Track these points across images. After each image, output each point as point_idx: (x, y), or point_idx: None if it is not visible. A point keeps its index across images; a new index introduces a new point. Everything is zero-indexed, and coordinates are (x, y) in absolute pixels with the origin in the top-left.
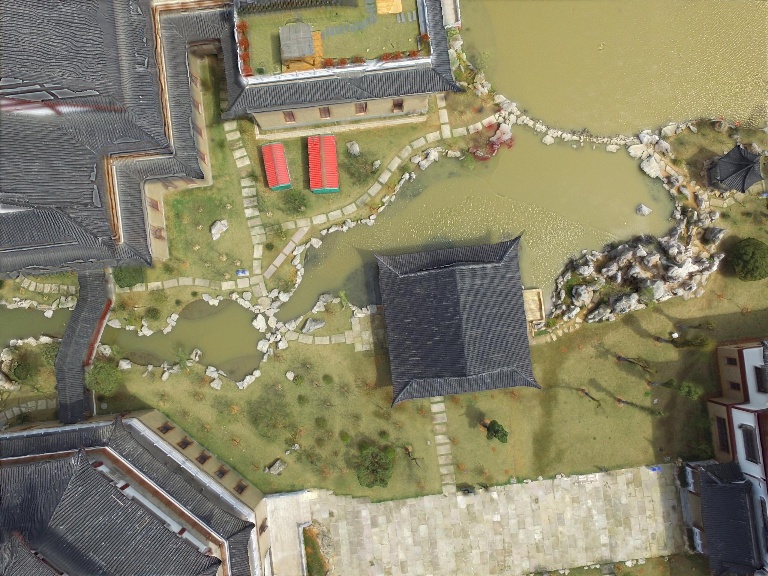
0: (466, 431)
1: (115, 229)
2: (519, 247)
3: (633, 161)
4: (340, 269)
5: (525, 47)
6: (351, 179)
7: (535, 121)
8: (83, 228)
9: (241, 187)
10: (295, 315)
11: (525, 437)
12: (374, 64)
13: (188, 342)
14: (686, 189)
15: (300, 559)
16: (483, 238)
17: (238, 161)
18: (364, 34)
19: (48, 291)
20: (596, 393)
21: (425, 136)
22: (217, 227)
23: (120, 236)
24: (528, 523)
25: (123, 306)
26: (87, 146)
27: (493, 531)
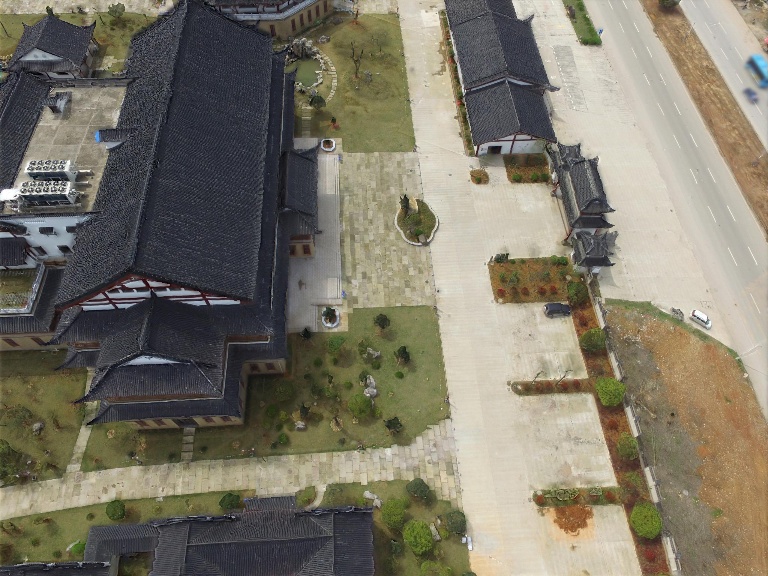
0: None
1: None
2: None
3: None
4: None
5: None
6: None
7: None
8: None
9: None
10: None
11: None
12: None
13: None
14: None
15: None
16: None
17: None
18: None
19: None
20: (2, 35)
21: None
22: None
23: None
24: (60, 2)
25: None
26: None
27: (77, 1)
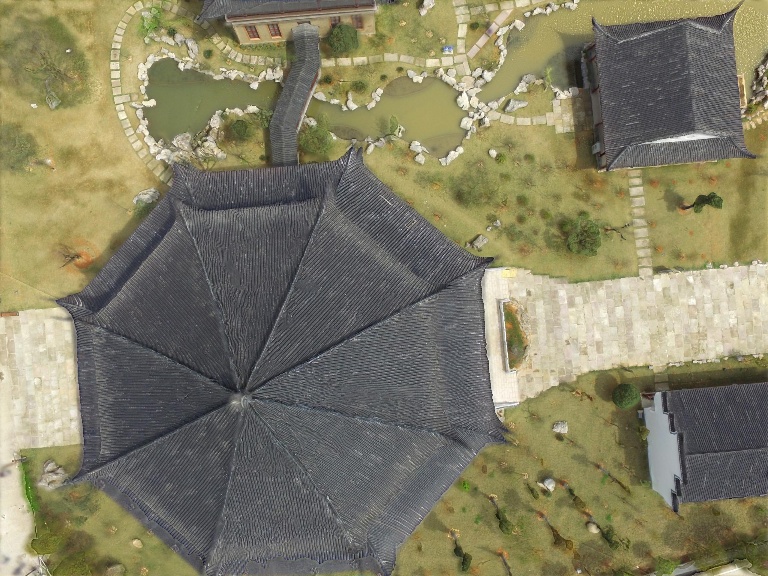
0: (664, 215)
1: None
2: None
3: None
4: (541, 53)
5: None
6: None
7: None
8: None
9: None
10: (497, 96)
11: (722, 223)
12: None
13: None
14: None
15: (499, 334)
16: None
17: None
18: None
19: (255, 63)
20: None
21: None
22: None
23: None
24: (723, 308)
25: (330, 78)
26: None
27: (688, 315)
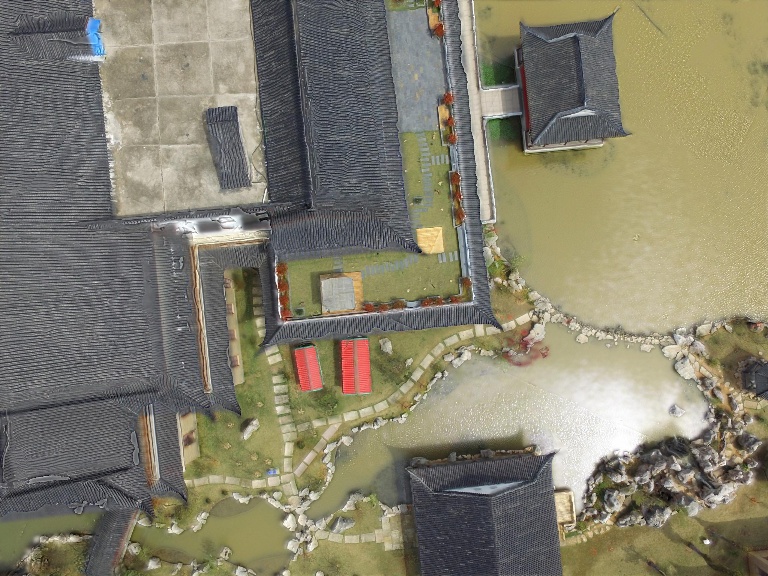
0: None
1: (152, 469)
2: (551, 447)
3: (667, 361)
4: (371, 466)
5: (559, 235)
6: (383, 376)
7: (569, 318)
8: (124, 493)
9: (273, 384)
10: (325, 513)
11: None
12: (415, 306)
13: (218, 540)
14: (720, 391)
15: None
16: (515, 437)
17: (270, 358)
18: (405, 274)
19: None
20: None
21: (458, 333)
22: (249, 431)
23: (157, 473)
24: None
25: (154, 505)
26: (128, 408)
27: None
